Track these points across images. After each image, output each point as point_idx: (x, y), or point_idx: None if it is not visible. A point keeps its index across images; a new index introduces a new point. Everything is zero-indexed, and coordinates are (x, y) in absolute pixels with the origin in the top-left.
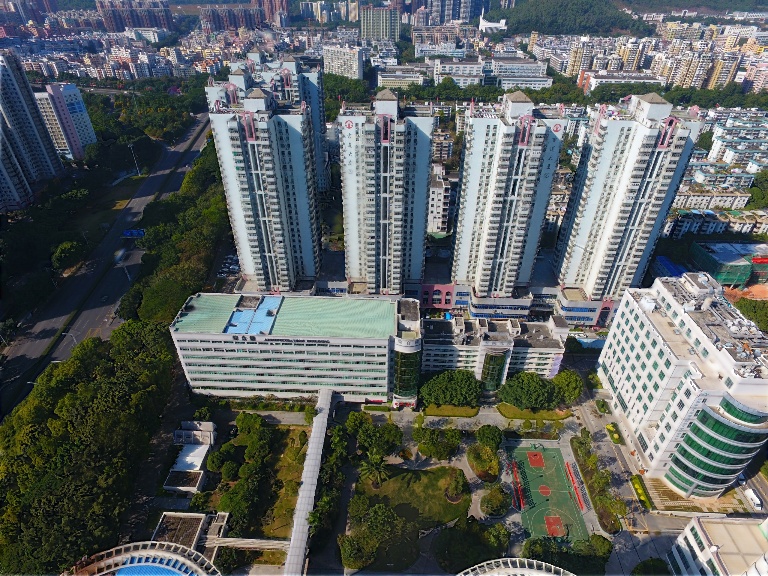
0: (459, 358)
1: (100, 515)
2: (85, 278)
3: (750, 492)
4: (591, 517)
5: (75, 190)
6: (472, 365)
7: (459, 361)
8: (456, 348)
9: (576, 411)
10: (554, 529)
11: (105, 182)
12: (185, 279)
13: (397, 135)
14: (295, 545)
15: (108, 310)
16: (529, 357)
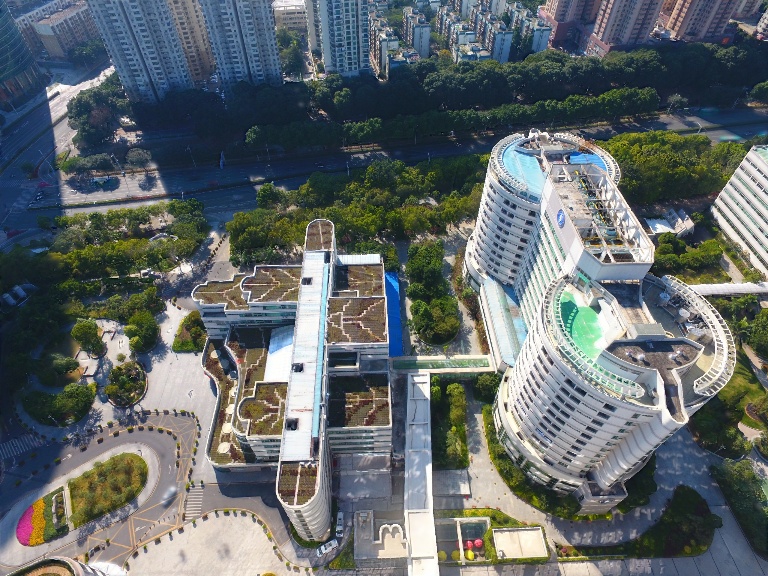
0: None
1: None
2: (758, 115)
3: None
4: None
5: None
6: None
7: None
8: None
9: None
10: None
11: None
12: None
13: None
14: None
15: (740, 140)
16: None
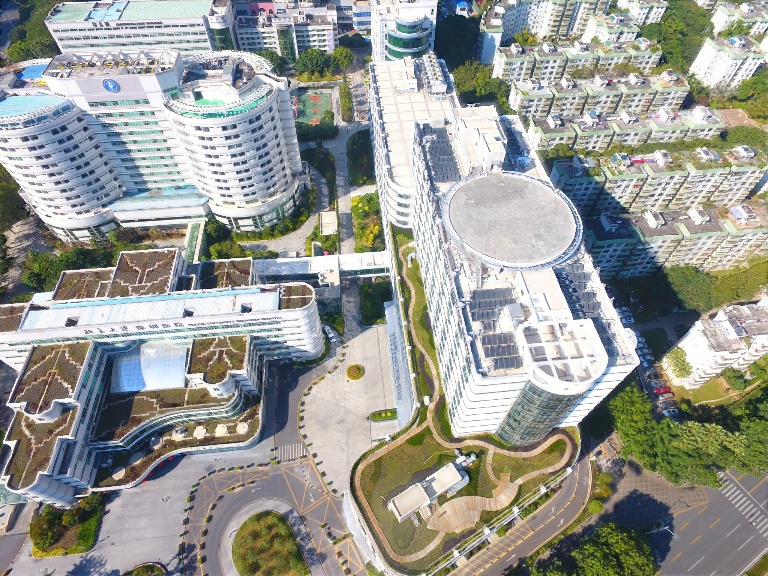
0: (264, 40)
1: None
2: None
3: None
4: (338, 117)
5: None
6: (275, 46)
7: (265, 44)
8: (259, 30)
9: (350, 76)
10: (314, 123)
11: None
12: None
13: None
14: None
15: (1, 49)
16: (311, 35)
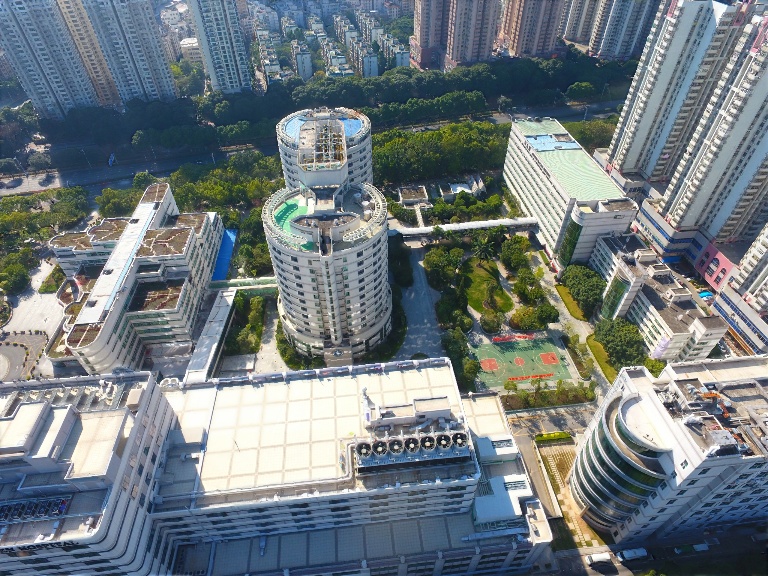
0: (610, 270)
1: (410, 161)
2: (572, 110)
3: (605, 554)
4: None
5: None
6: None
7: (610, 275)
8: (612, 257)
9: None
10: (486, 363)
11: None
12: (591, 130)
13: (765, 45)
14: (422, 228)
15: None
16: (648, 316)
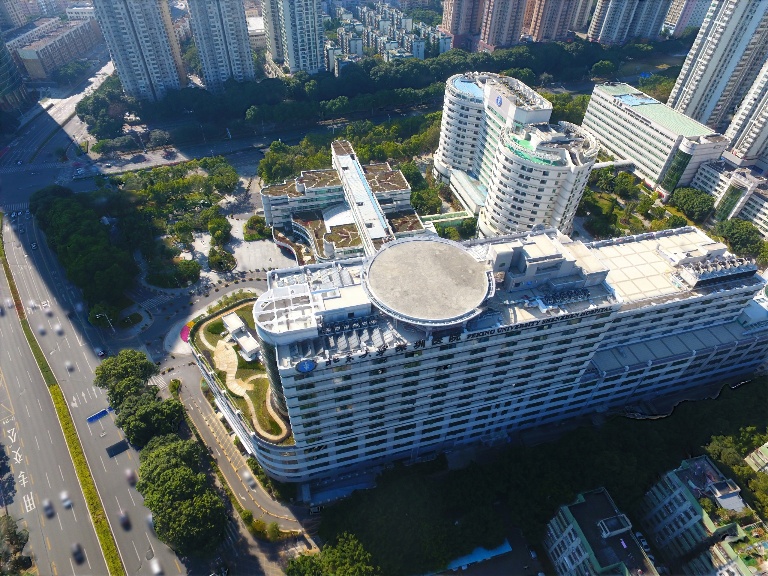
0: (717, 187)
1: None
2: None
3: None
4: None
5: (646, 44)
6: None
7: (716, 191)
8: (719, 176)
9: (759, 272)
10: None
11: (672, 52)
12: None
13: None
14: None
15: None
16: (762, 212)
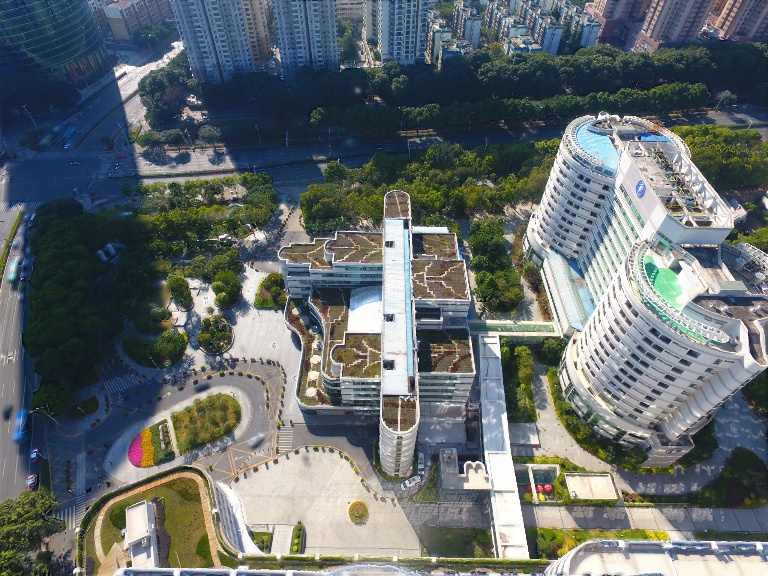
0: None
1: None
2: None
3: None
4: None
5: None
6: None
7: None
8: None
9: None
10: None
11: None
12: None
13: None
14: None
15: None
16: None
